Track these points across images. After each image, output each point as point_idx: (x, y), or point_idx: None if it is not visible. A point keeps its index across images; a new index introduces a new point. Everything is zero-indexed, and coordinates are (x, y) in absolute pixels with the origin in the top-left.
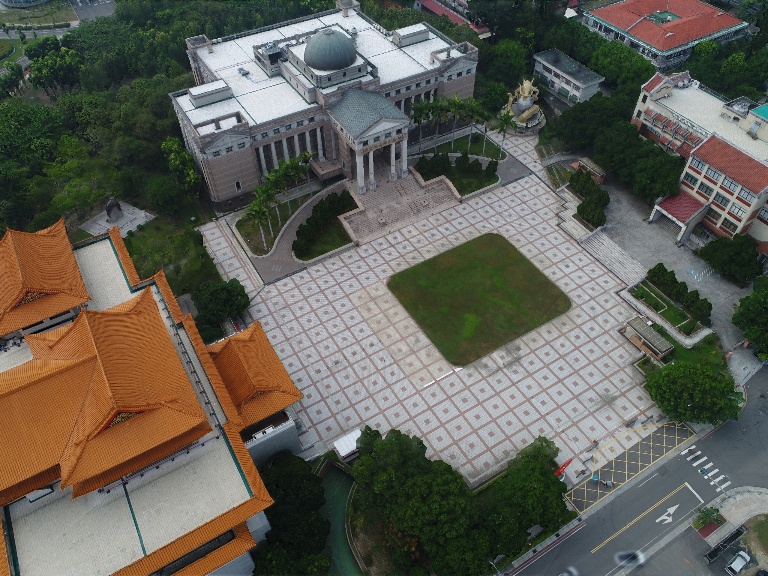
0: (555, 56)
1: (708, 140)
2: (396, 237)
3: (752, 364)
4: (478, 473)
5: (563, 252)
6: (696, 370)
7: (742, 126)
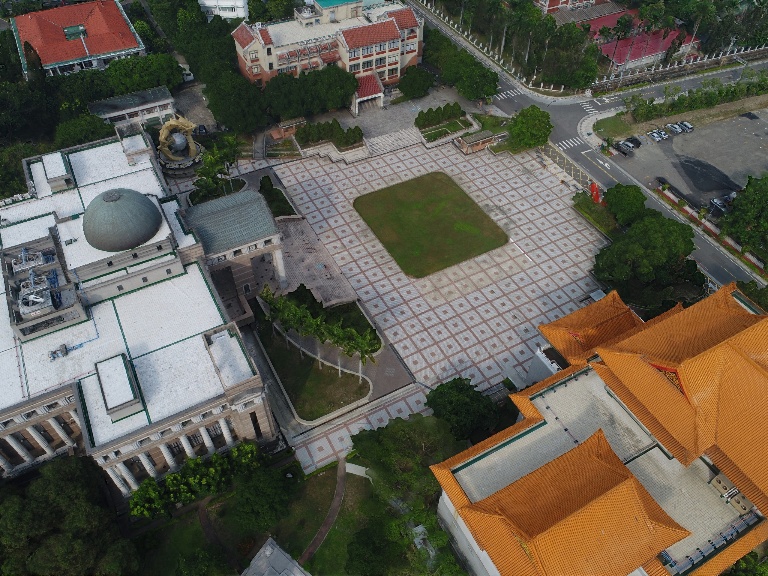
0: (103, 106)
1: (344, 36)
2: (350, 269)
3: (493, 108)
4: (599, 239)
5: (382, 166)
6: (528, 113)
7: (324, 22)
